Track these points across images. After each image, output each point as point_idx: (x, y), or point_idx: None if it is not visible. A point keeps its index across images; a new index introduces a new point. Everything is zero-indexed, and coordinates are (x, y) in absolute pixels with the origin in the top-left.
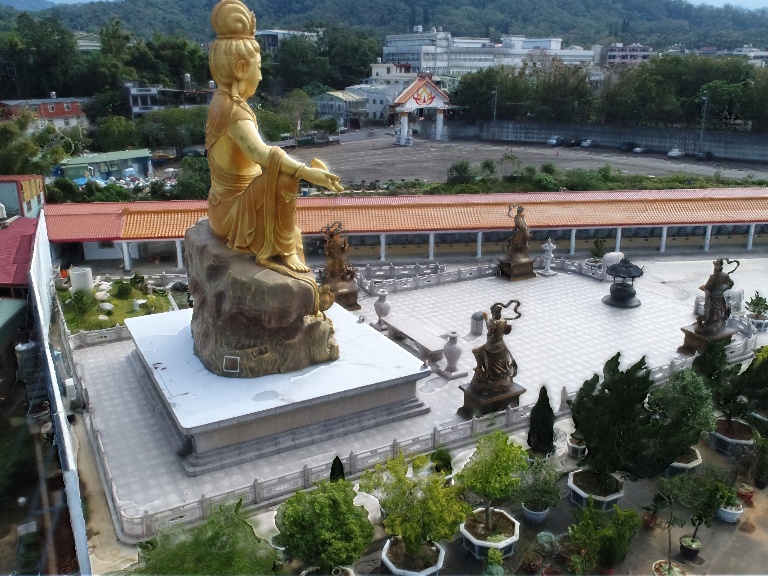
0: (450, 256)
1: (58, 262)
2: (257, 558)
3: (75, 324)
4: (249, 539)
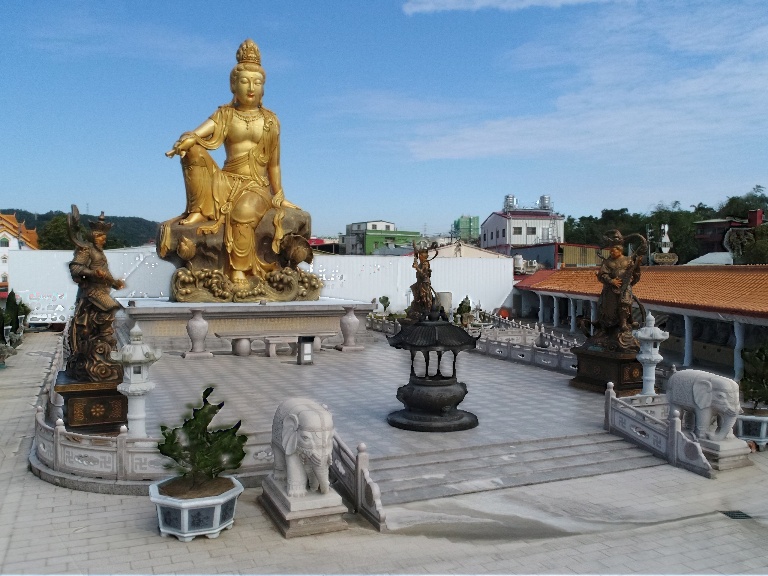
0: (719, 371)
1: (530, 310)
2: None
3: None
4: None
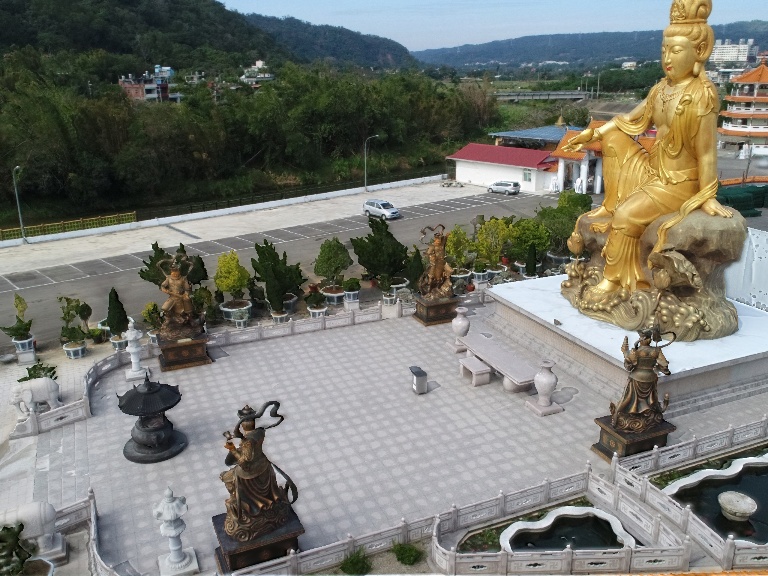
0: None
1: None
2: None
3: None
4: None
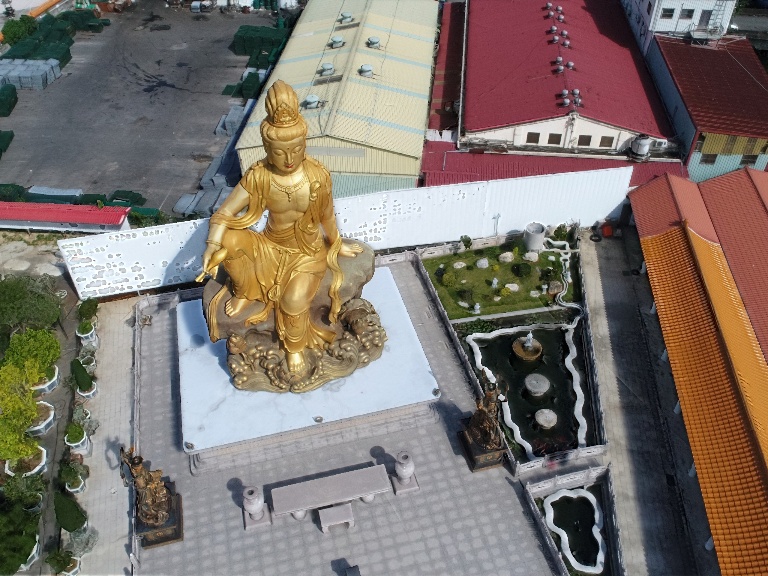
0: None
1: None
2: (2, 314)
3: (471, 255)
4: (22, 315)
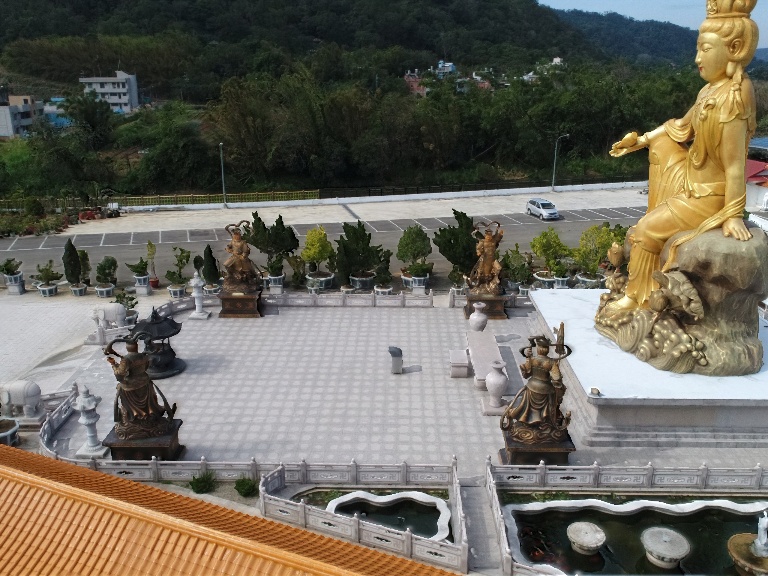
0: None
1: None
2: None
3: None
4: None
